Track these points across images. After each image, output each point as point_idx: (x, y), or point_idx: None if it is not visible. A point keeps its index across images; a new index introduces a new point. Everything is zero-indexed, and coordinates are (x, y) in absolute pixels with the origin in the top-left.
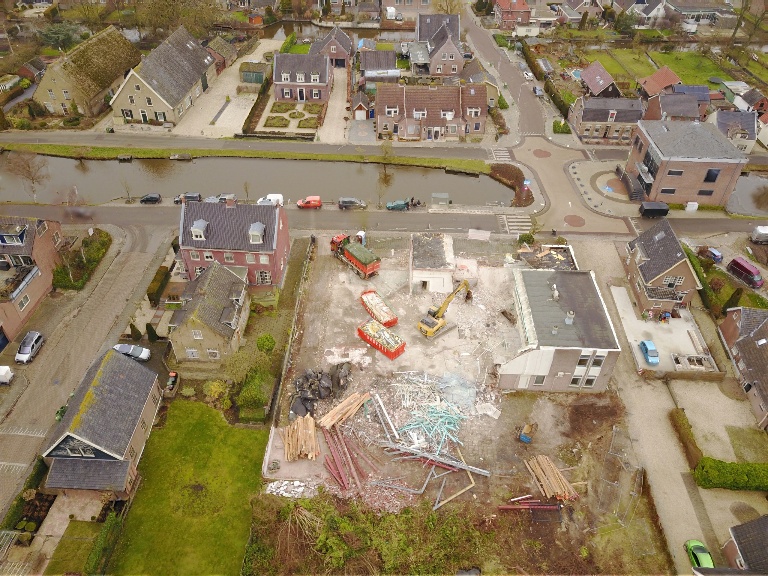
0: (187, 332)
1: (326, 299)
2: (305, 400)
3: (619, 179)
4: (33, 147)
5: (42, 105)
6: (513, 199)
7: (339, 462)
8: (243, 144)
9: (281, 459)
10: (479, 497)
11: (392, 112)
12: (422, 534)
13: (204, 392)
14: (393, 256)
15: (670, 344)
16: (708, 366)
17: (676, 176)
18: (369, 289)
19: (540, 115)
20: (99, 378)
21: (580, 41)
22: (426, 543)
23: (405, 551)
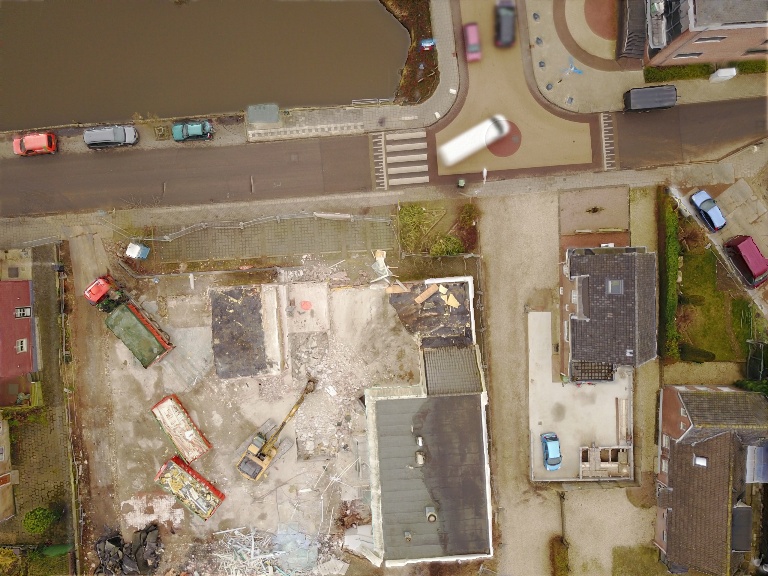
0: None
1: (106, 401)
2: None
3: None
4: None
5: None
6: (402, 75)
7: None
8: None
9: None
10: None
11: None
12: None
13: None
14: (194, 291)
15: (585, 426)
16: (623, 463)
17: (710, 41)
18: (165, 376)
19: None
20: None
21: None
22: None
23: None
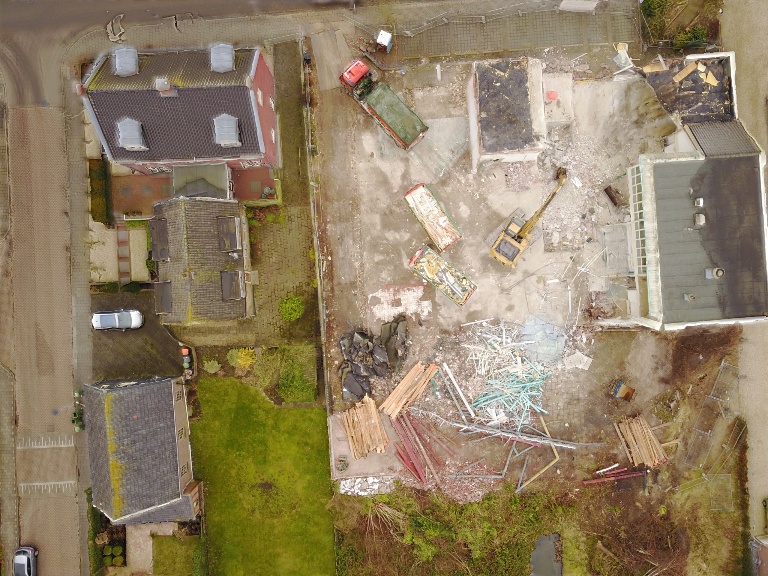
0: None
1: (352, 194)
2: (358, 376)
3: None
4: None
5: None
6: None
7: (412, 453)
8: None
9: (347, 454)
10: (563, 472)
11: None
12: (504, 513)
13: (231, 365)
14: (440, 82)
15: None
16: None
17: None
18: (412, 167)
19: None
20: (112, 439)
21: None
22: (509, 523)
23: (489, 534)
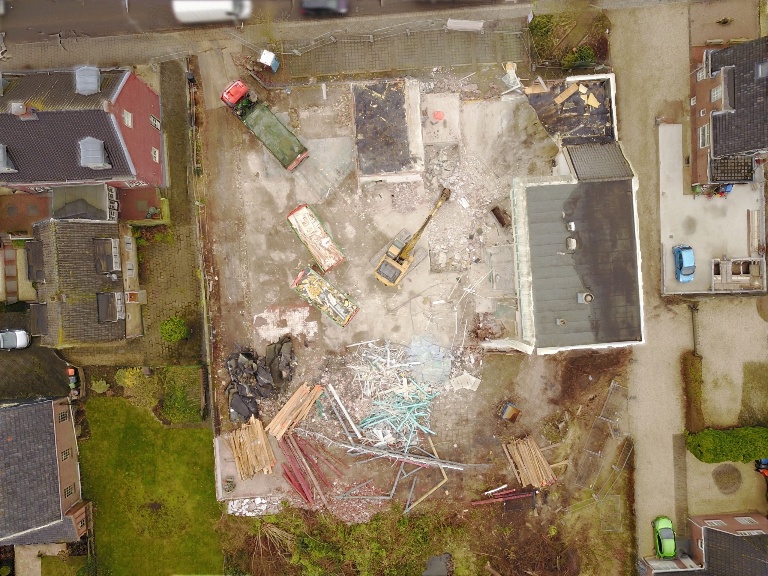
0: None
1: (238, 214)
2: (244, 397)
3: None
4: None
5: None
6: None
7: (299, 474)
8: None
9: (234, 475)
10: (451, 493)
11: None
12: (394, 534)
13: (119, 385)
14: (326, 101)
15: (716, 238)
16: (755, 275)
17: None
18: (297, 187)
19: None
20: None
21: None
22: (398, 543)
23: (378, 555)
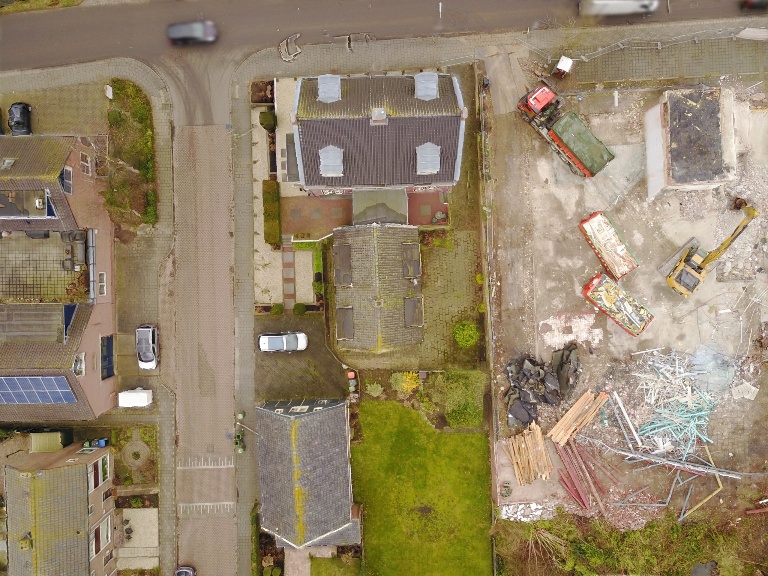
0: None
1: (525, 220)
2: (526, 403)
3: None
4: None
5: None
6: None
7: (577, 481)
8: None
9: (511, 480)
10: (726, 502)
11: None
12: (664, 541)
13: (394, 388)
14: (617, 108)
15: None
16: None
17: None
18: (586, 194)
19: None
20: (299, 466)
21: None
22: (669, 551)
23: (649, 562)
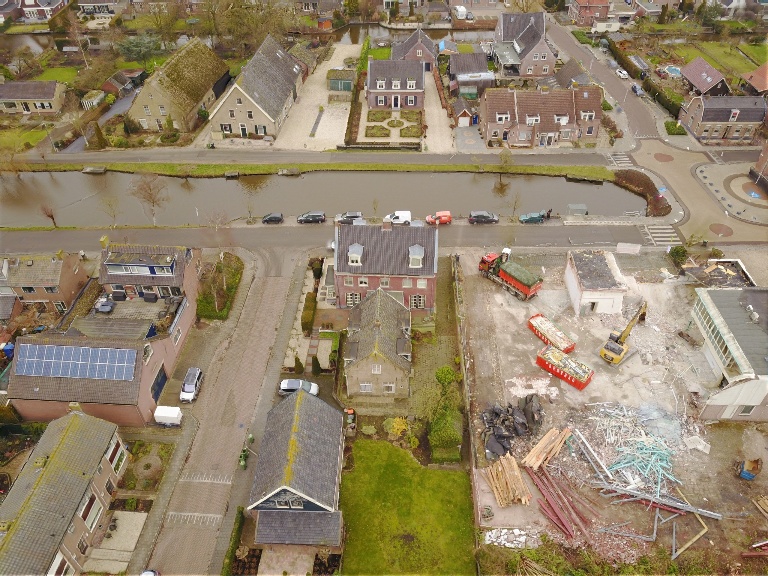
0: (365, 366)
1: (489, 324)
2: (500, 437)
3: (754, 183)
4: (136, 166)
5: (136, 122)
6: (648, 208)
7: (556, 507)
8: (350, 156)
9: (492, 504)
10: (717, 543)
11: (503, 118)
12: None
13: (386, 430)
14: (545, 274)
15: None
16: None
17: None
18: (531, 312)
19: (649, 116)
20: (298, 423)
21: (663, 35)
22: None
23: None
